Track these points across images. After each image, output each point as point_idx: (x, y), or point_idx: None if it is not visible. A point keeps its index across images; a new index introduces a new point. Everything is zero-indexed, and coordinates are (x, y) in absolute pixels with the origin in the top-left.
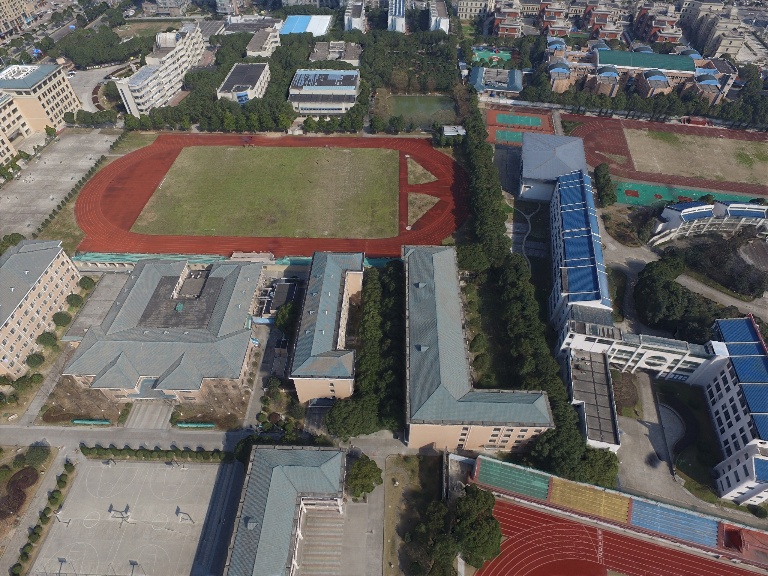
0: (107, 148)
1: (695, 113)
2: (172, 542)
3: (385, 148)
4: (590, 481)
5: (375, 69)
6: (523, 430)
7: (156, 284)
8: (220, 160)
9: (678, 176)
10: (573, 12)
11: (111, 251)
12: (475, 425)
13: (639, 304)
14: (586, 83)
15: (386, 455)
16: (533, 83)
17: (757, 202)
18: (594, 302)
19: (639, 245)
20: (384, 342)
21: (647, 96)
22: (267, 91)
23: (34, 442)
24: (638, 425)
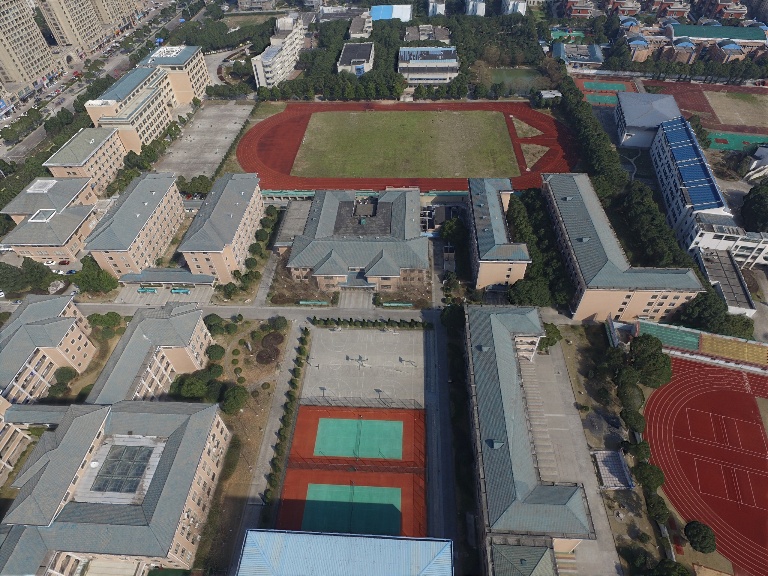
0: (247, 115)
1: None
2: (403, 378)
3: (490, 110)
4: (734, 335)
5: (468, 46)
6: (675, 297)
7: (337, 207)
8: (347, 122)
9: (761, 127)
10: None
11: (280, 189)
12: (640, 289)
13: (749, 218)
14: (663, 54)
15: (556, 325)
16: (613, 55)
17: None
18: (718, 209)
19: (736, 179)
20: (542, 243)
21: (722, 63)
22: (377, 65)
23: (270, 317)
24: (762, 305)
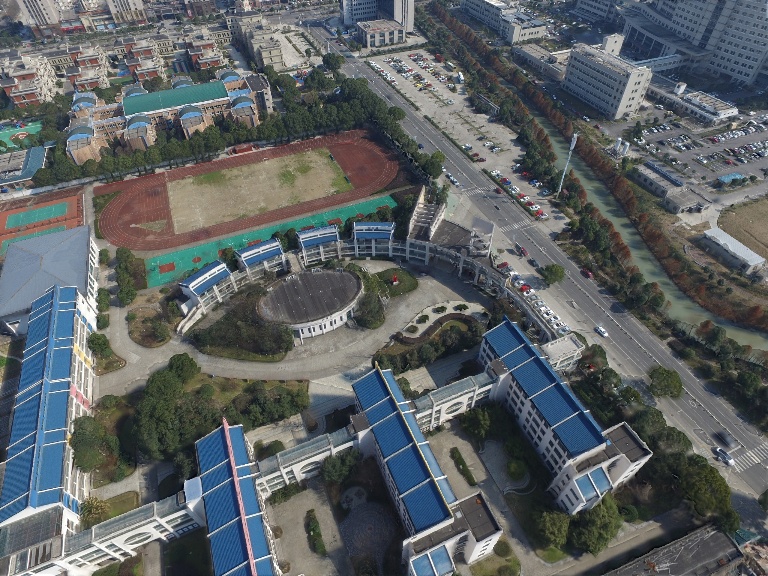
0: None
1: (237, 142)
2: None
3: None
4: None
5: None
6: None
7: None
8: None
9: (220, 224)
10: (120, 53)
11: None
12: None
13: None
14: (120, 141)
15: None
16: None
17: (275, 237)
18: (24, 512)
19: (167, 340)
20: None
21: (186, 137)
22: None
23: None
24: None
